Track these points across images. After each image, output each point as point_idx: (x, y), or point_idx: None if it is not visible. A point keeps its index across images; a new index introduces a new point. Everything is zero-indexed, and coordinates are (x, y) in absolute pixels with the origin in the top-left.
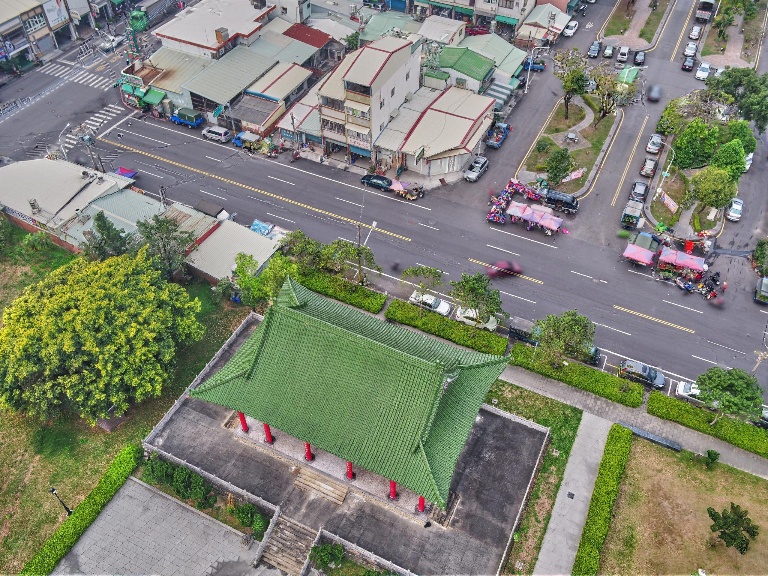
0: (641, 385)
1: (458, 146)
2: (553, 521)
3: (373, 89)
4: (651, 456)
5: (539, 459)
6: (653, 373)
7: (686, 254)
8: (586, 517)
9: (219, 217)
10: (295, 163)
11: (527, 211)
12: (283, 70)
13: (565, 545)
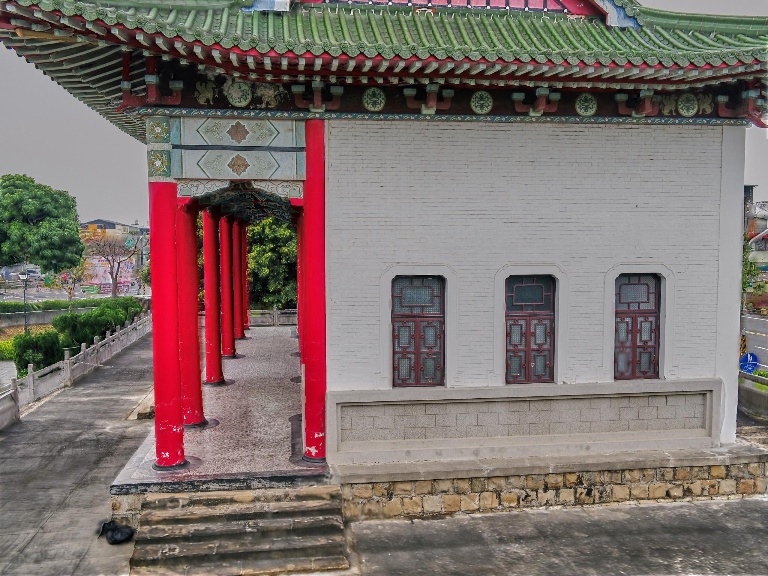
0: None
1: None
2: None
3: None
4: None
5: None
6: None
7: None
8: None
9: None
10: None
11: None
12: None
13: None
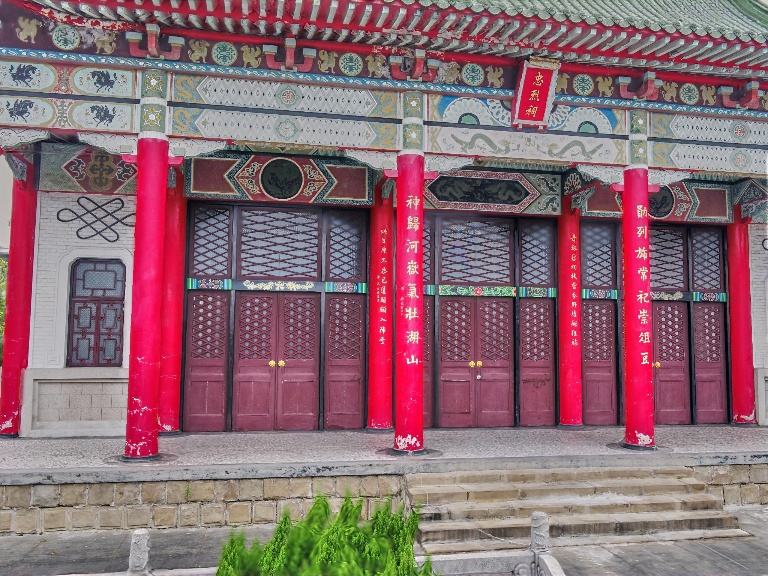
0: None
1: None
2: None
3: None
4: None
5: None
6: None
7: None
8: None
9: None
10: None
11: None
12: None
13: None
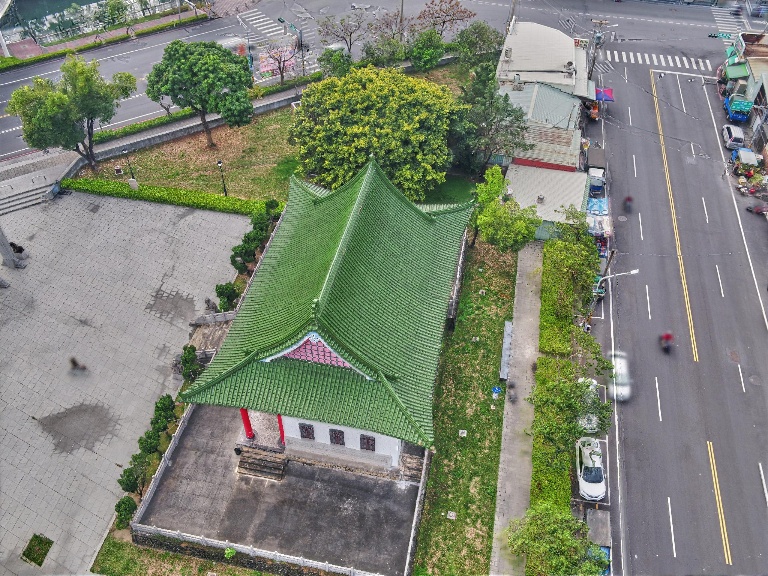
0: None
1: None
2: None
3: None
4: None
5: (356, 575)
6: None
7: None
8: None
9: (591, 170)
10: (749, 213)
11: None
12: None
13: None
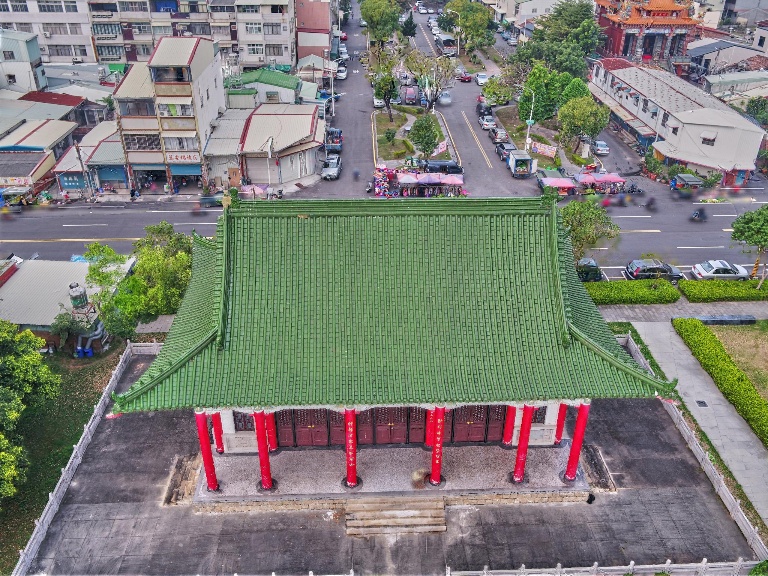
0: (663, 279)
1: (308, 136)
2: (712, 437)
3: (192, 73)
4: (735, 336)
5: None
6: (665, 265)
7: (599, 173)
8: (740, 418)
9: None
10: None
11: (420, 176)
12: (36, 125)
13: (751, 456)
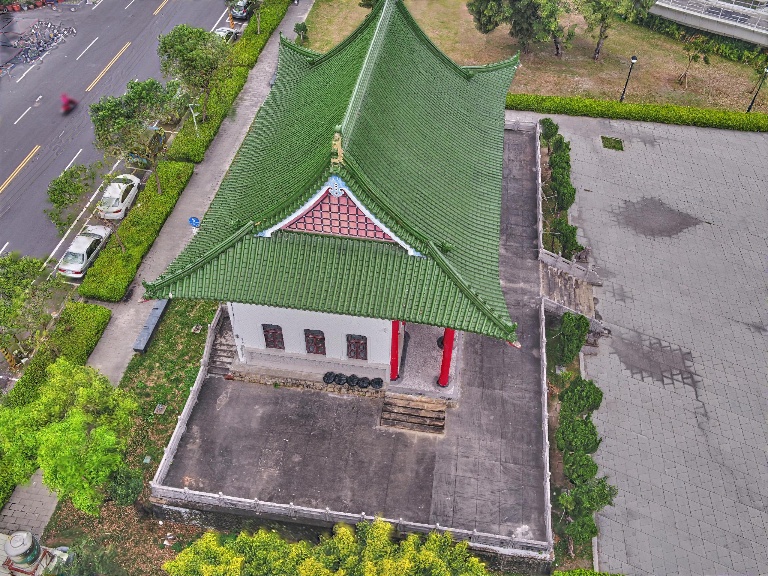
0: None
1: None
2: None
3: None
4: None
5: None
6: None
7: (6, 26)
8: None
9: None
10: None
11: None
12: None
13: None
